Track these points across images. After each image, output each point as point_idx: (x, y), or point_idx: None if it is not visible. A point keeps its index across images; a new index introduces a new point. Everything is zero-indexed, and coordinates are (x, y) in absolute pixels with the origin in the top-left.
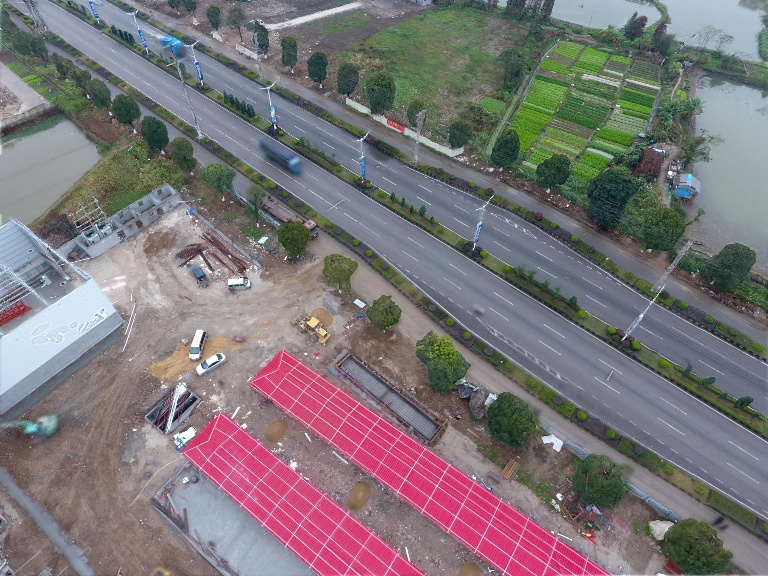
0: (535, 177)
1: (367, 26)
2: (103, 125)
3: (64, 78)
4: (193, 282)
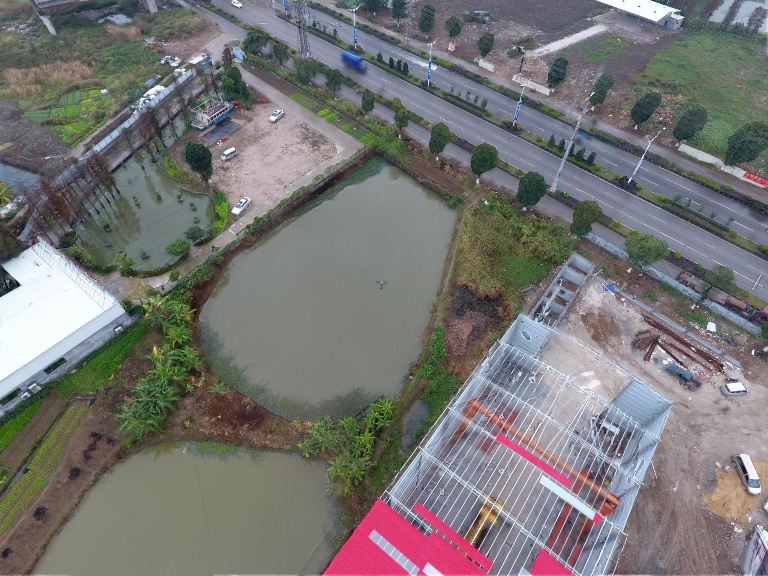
0: None
1: (631, 53)
2: (435, 172)
3: (361, 114)
4: (674, 383)
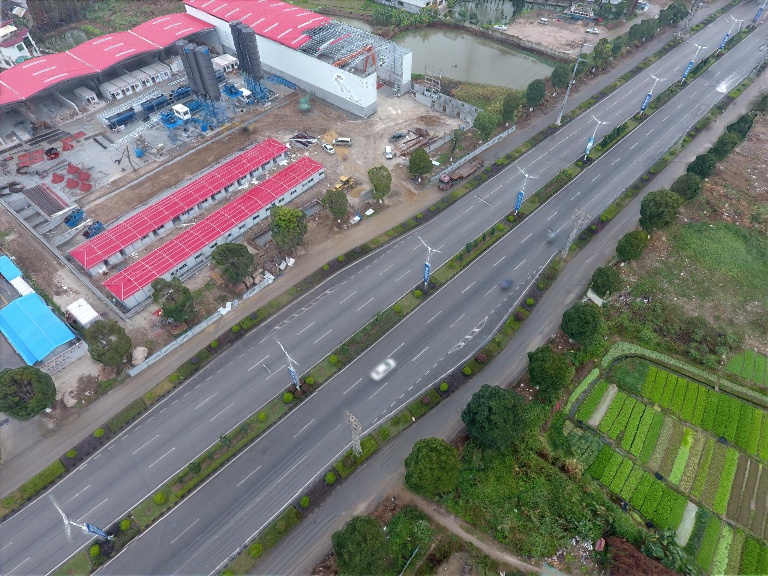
0: None
1: None
2: None
3: (614, 57)
4: None
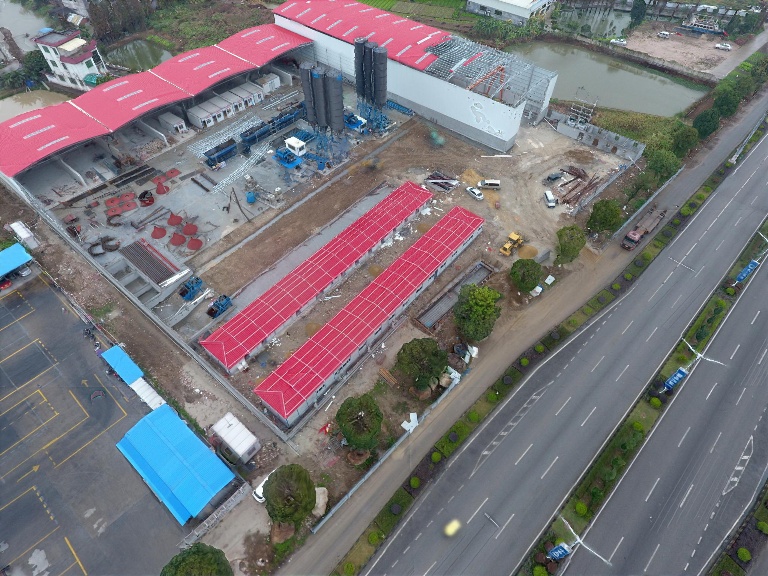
0: None
1: None
2: None
3: None
4: None
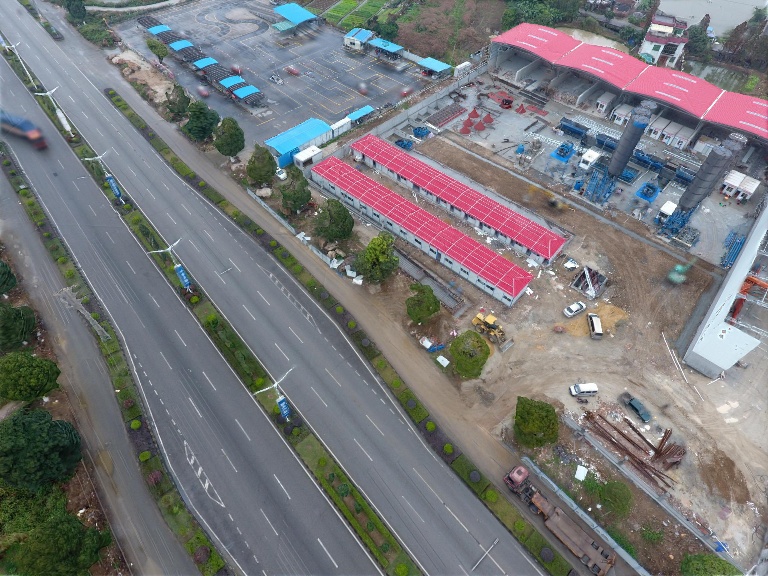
0: None
1: None
2: None
3: None
4: None
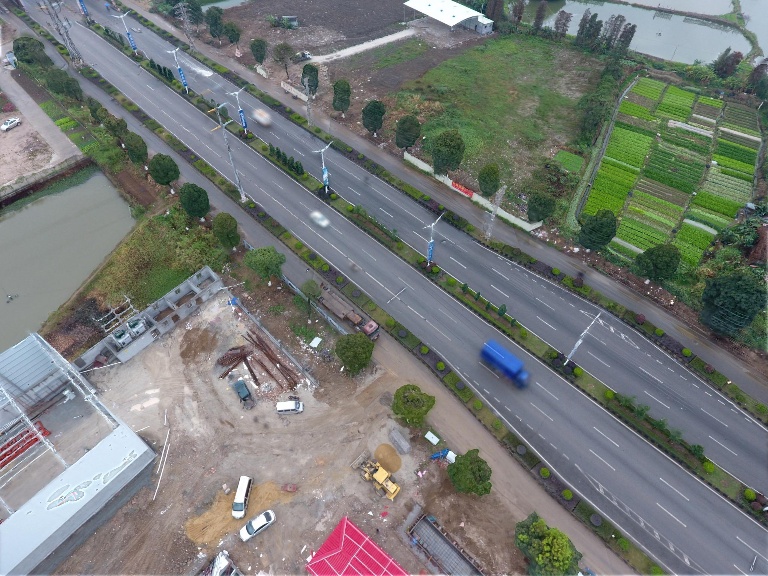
0: (630, 262)
1: (423, 59)
2: (138, 182)
3: (98, 122)
4: (236, 401)
